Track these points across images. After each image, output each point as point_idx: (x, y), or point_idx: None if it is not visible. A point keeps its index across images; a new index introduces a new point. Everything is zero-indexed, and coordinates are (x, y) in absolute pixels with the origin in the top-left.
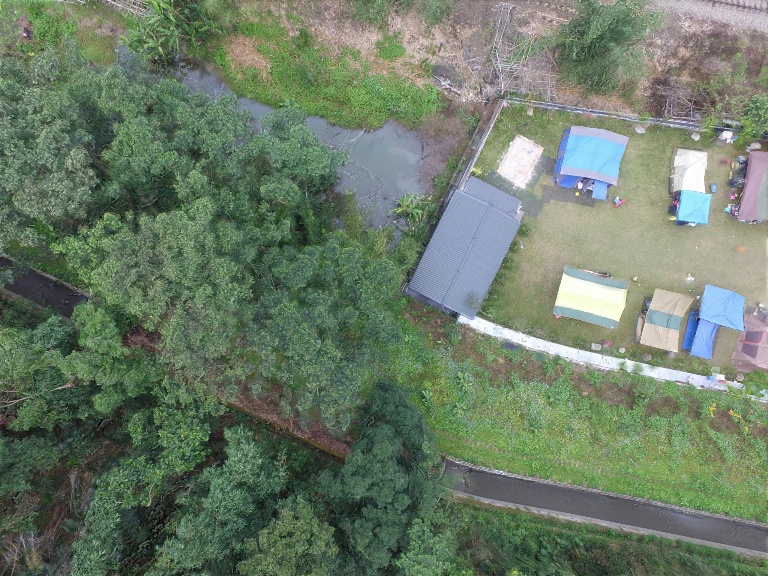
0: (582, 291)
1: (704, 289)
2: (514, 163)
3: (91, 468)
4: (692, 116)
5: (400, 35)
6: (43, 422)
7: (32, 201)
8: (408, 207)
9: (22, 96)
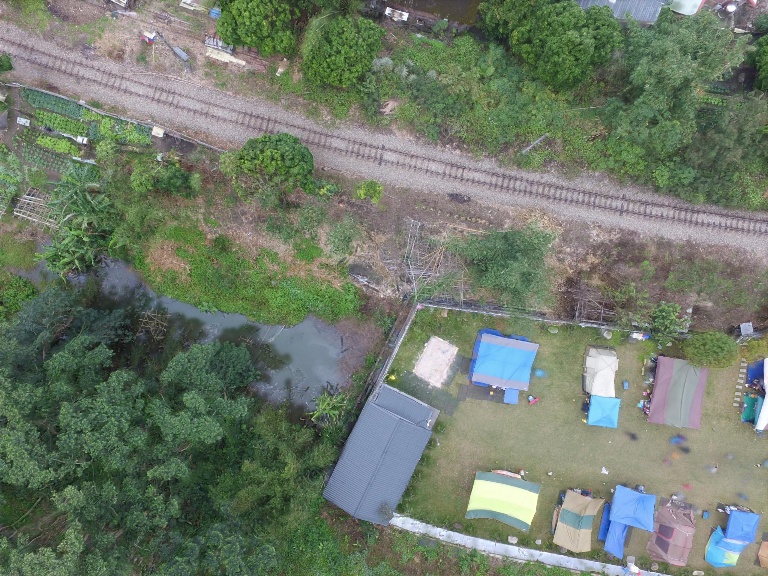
0: (494, 495)
1: (615, 489)
2: (430, 362)
3: None
4: (602, 319)
5: (317, 237)
6: None
7: None
8: (324, 410)
9: None
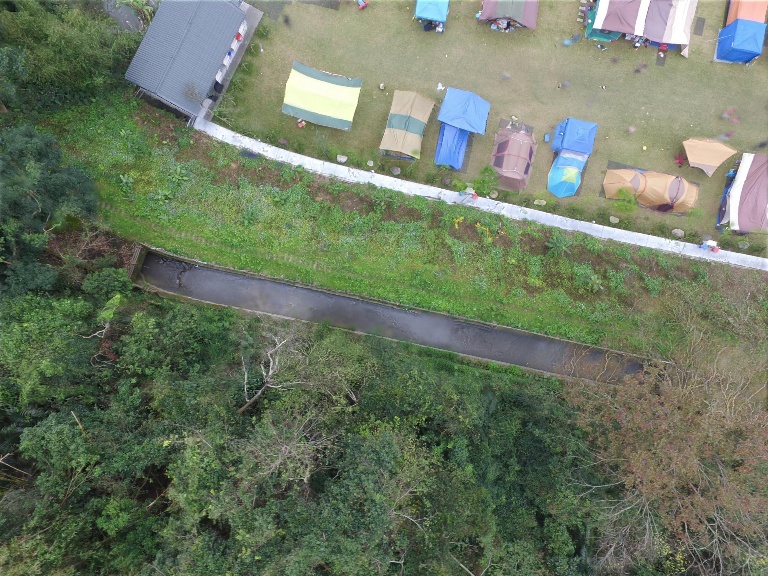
0: (315, 90)
1: (446, 92)
2: None
3: None
4: None
5: None
6: None
7: None
8: (135, 2)
9: None
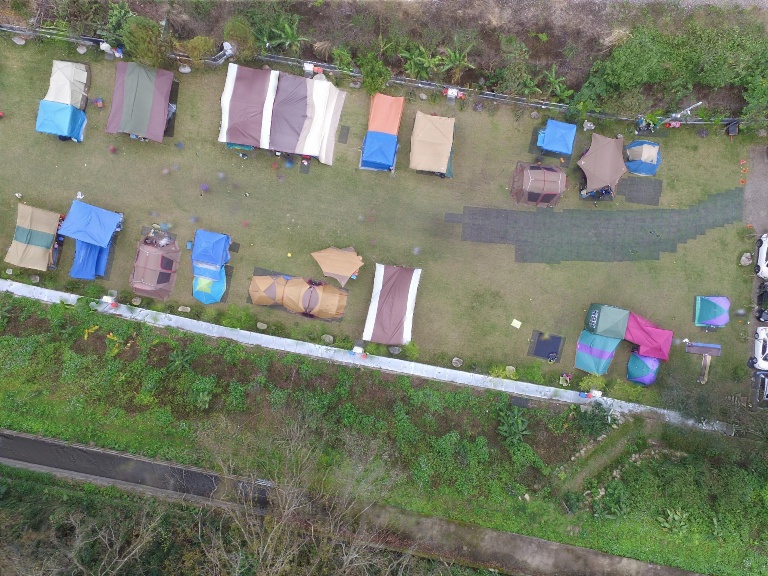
0: None
1: None
2: None
3: None
4: (63, 26)
5: None
6: None
7: None
8: None
9: None
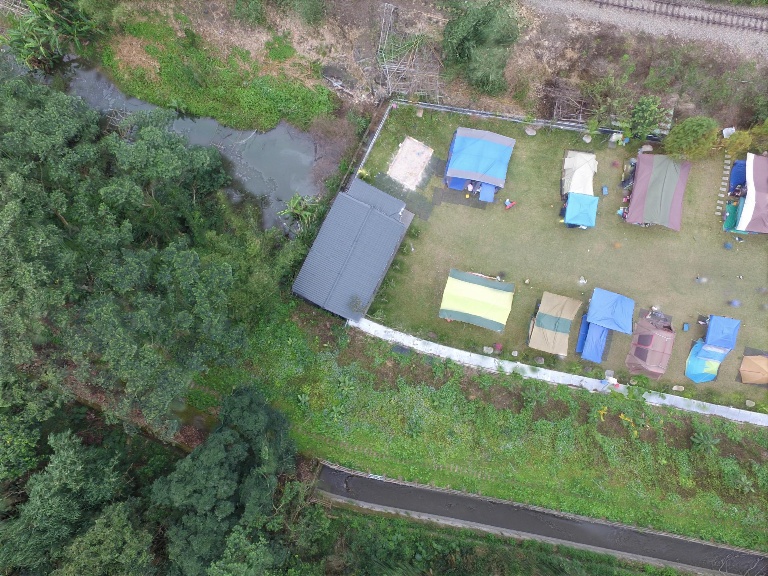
0: (469, 294)
1: (593, 292)
2: (404, 165)
3: None
4: (581, 118)
5: (289, 36)
6: None
7: None
8: (295, 209)
9: None
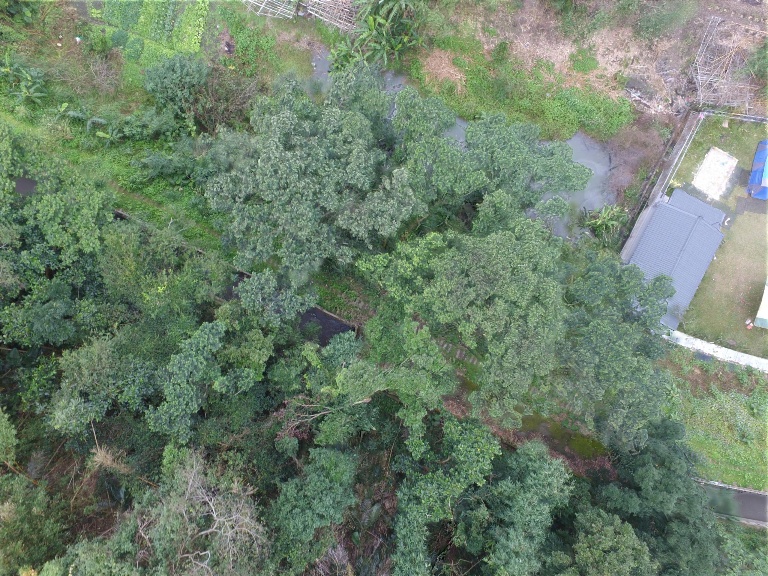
0: None
1: None
2: (707, 175)
3: (361, 479)
4: None
5: (594, 48)
6: (337, 435)
7: (361, 221)
8: (605, 219)
9: (321, 116)
